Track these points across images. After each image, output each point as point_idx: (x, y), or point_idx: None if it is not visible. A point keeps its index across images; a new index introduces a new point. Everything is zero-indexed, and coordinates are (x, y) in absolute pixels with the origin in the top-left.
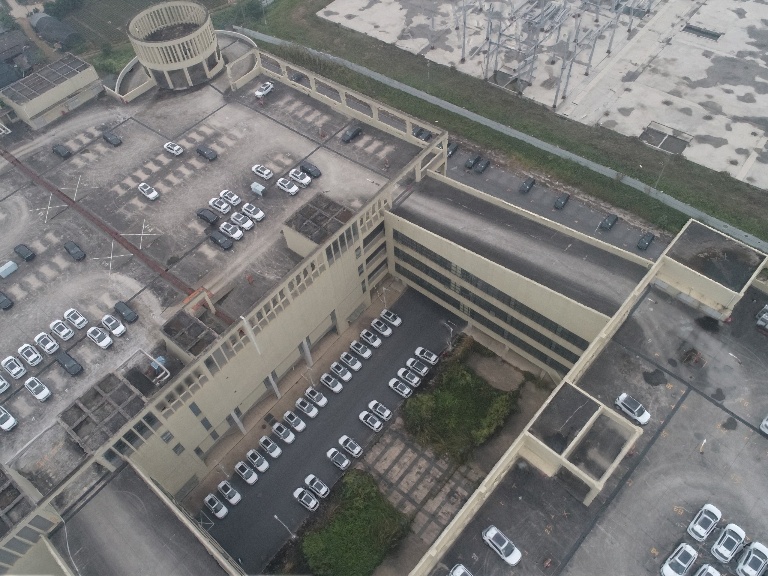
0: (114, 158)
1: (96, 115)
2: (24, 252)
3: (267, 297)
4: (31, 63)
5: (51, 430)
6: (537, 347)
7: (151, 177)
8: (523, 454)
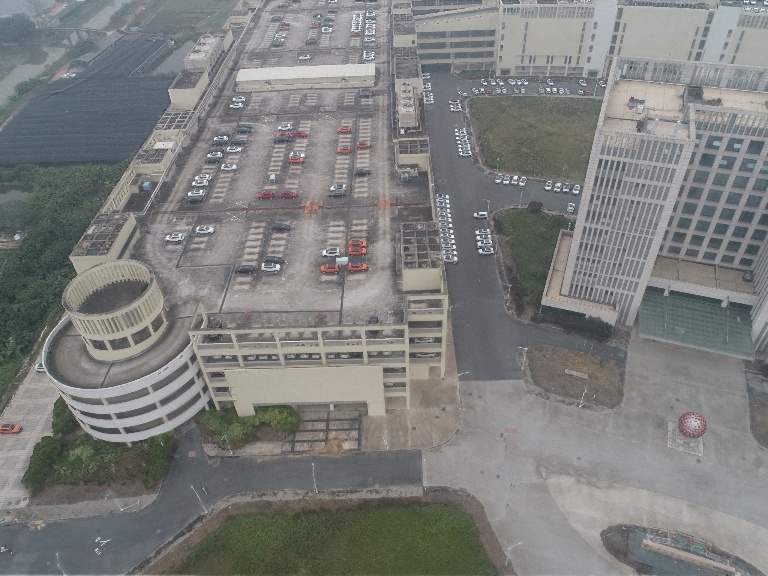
0: (304, 3)
1: (277, 1)
2: (320, 13)
3: None
4: (163, 36)
5: (385, 24)
6: (468, 7)
7: (326, 1)
8: None
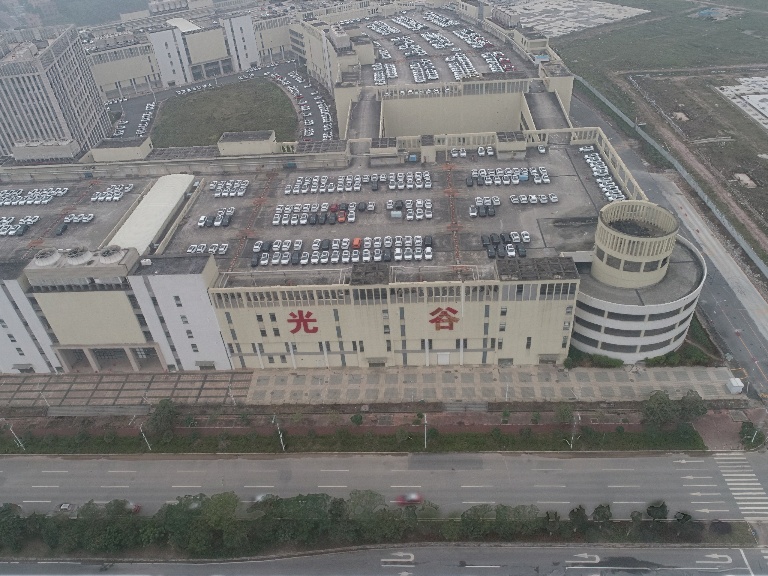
0: None
1: None
2: (293, 6)
3: (343, 4)
4: None
5: None
6: None
7: None
8: (377, 11)
